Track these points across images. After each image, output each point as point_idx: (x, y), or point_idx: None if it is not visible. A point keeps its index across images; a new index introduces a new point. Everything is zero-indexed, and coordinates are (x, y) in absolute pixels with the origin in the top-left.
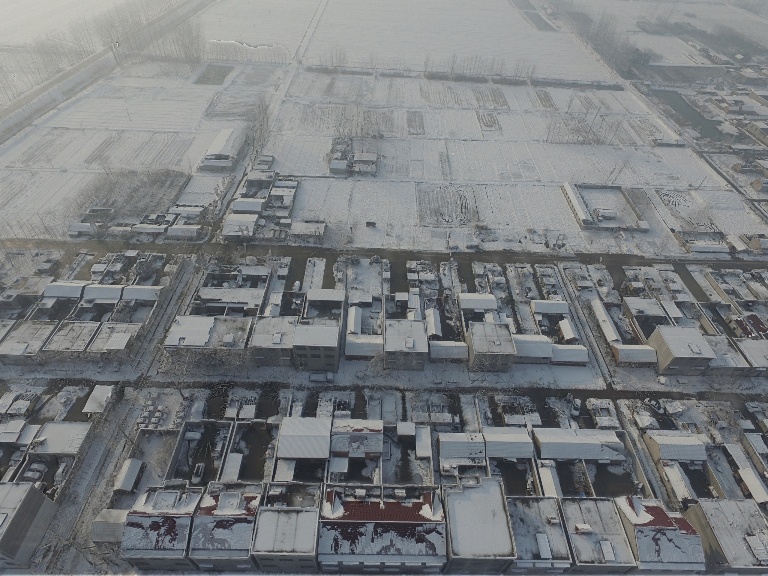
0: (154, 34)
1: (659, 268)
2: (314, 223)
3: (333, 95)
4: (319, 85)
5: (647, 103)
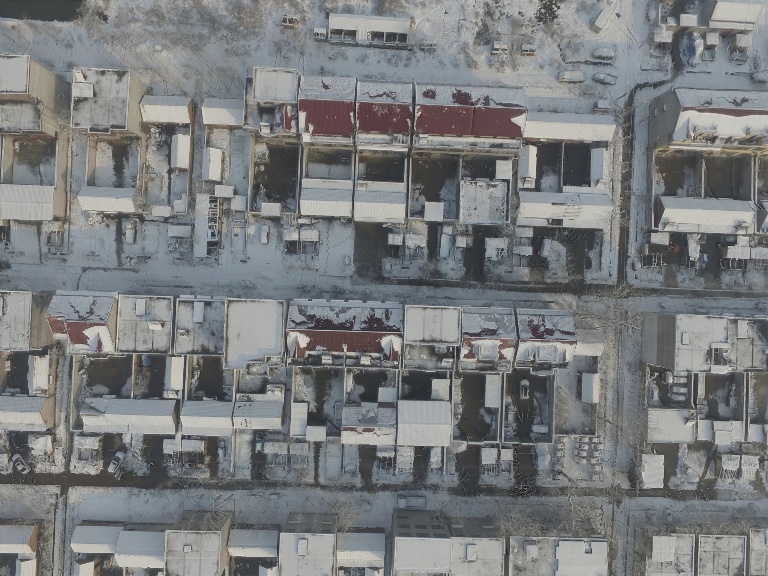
0: None
1: None
2: None
3: None
4: None
5: None
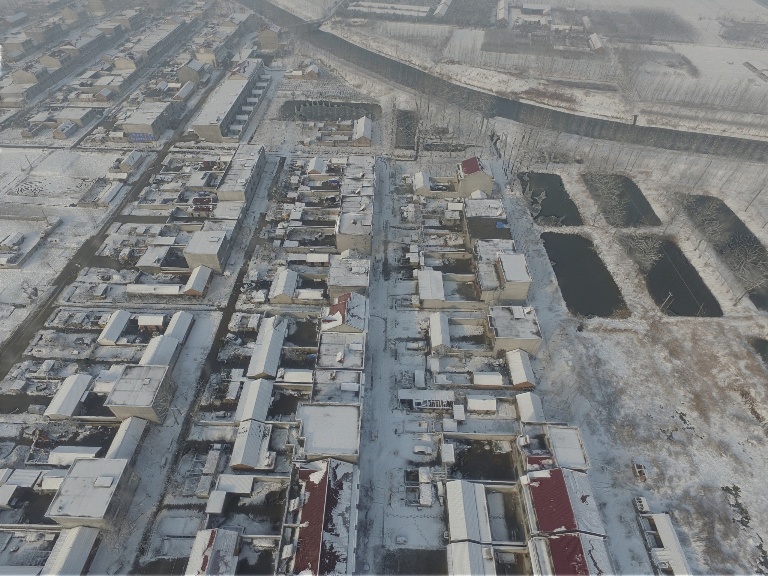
0: None
1: (113, 231)
2: None
3: None
4: None
5: None
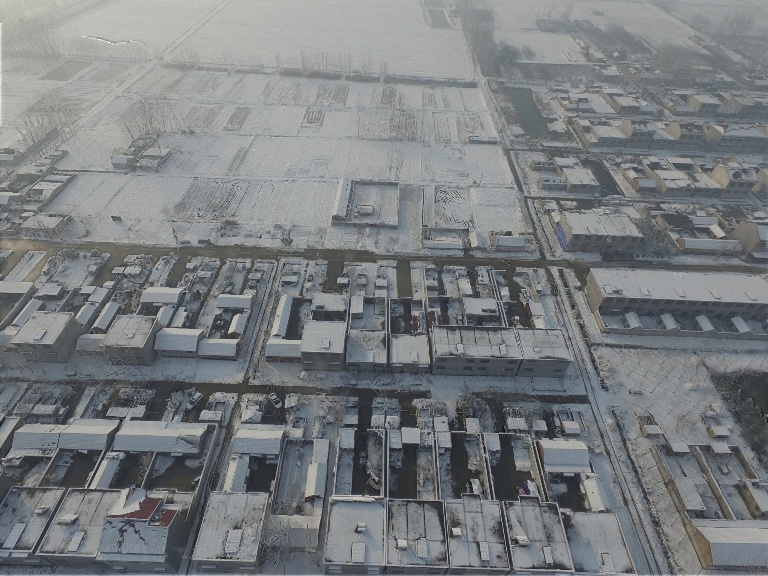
0: (8, 30)
1: (381, 264)
2: (52, 217)
3: (173, 91)
4: (166, 81)
5: (489, 100)
